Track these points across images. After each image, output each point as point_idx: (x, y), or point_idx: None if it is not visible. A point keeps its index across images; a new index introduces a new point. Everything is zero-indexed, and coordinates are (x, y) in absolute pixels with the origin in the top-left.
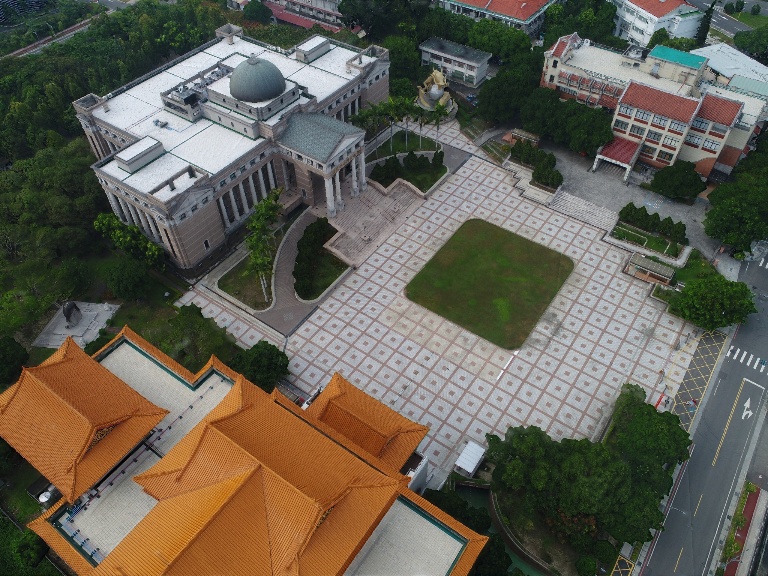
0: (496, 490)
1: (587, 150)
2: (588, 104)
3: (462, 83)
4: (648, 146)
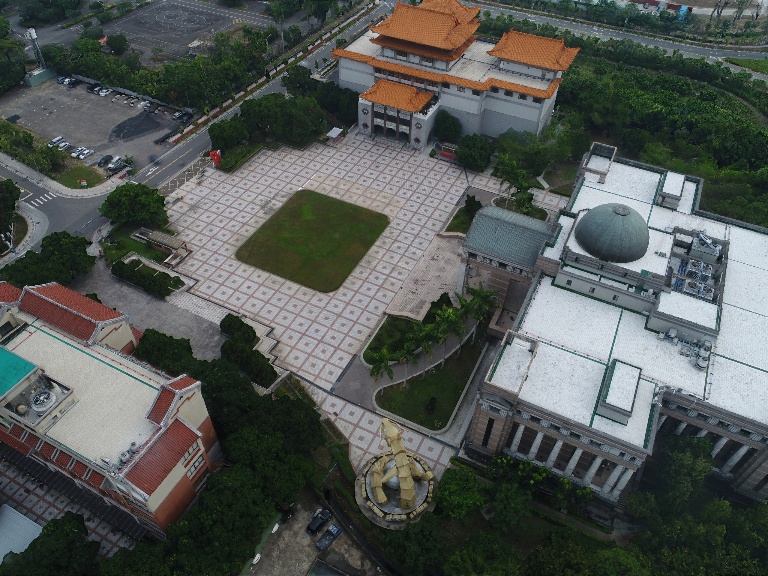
0: None
1: None
2: None
3: None
4: None
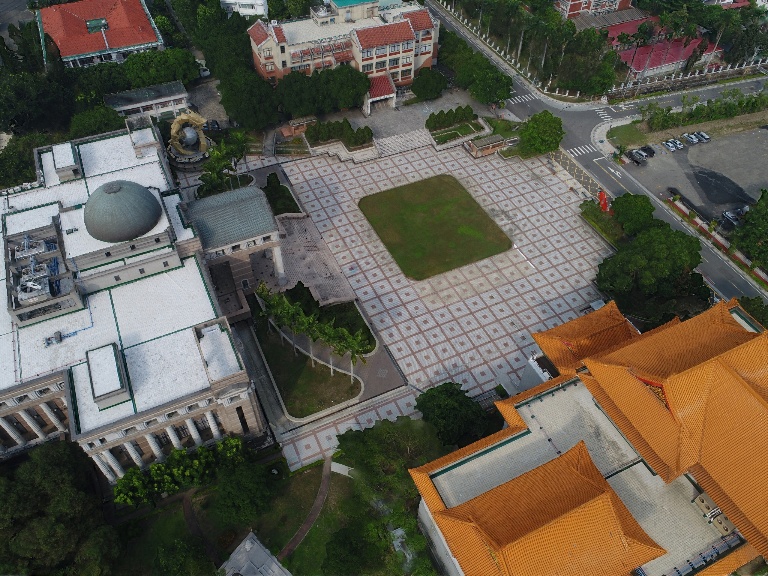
0: (629, 312)
1: (357, 102)
2: (324, 69)
3: None
4: (392, 73)
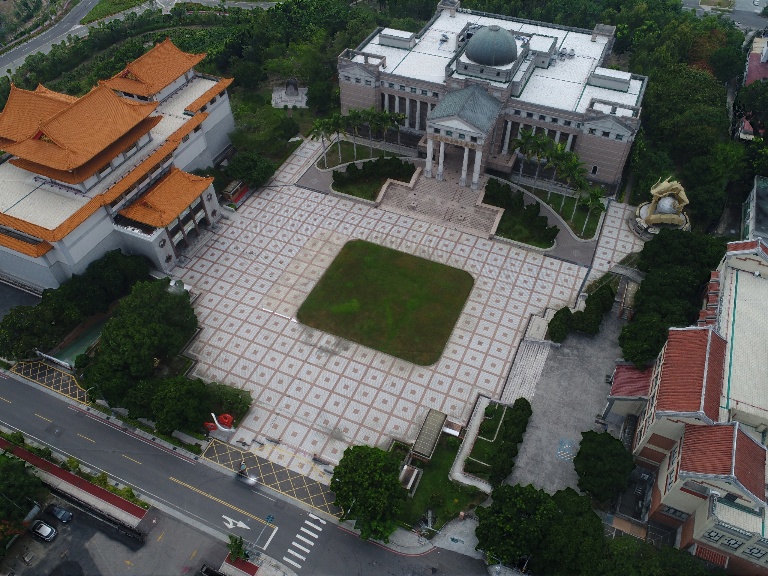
0: None
1: None
2: None
3: None
4: None
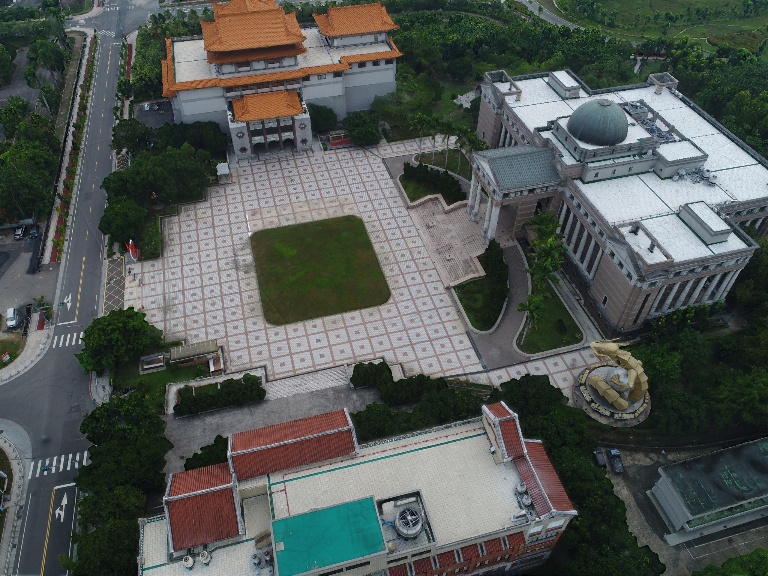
0: None
1: None
2: None
3: None
4: None
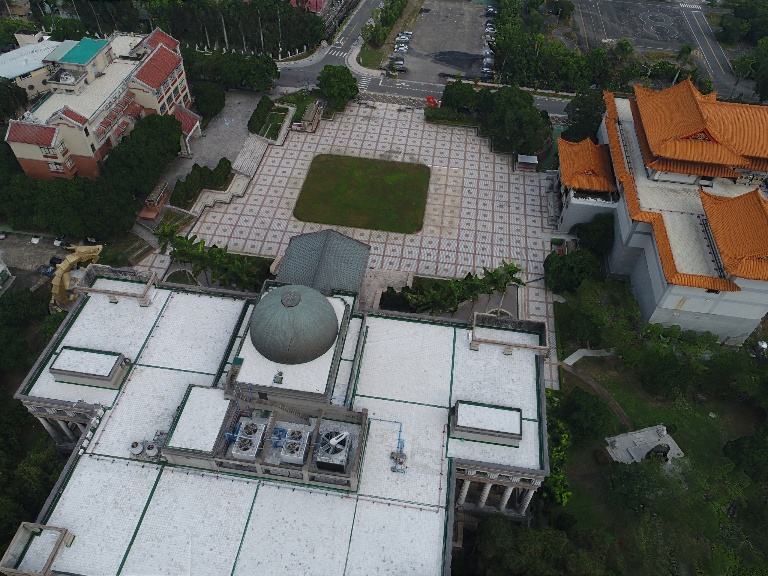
0: None
1: None
2: (123, 133)
3: (2, 293)
4: None
